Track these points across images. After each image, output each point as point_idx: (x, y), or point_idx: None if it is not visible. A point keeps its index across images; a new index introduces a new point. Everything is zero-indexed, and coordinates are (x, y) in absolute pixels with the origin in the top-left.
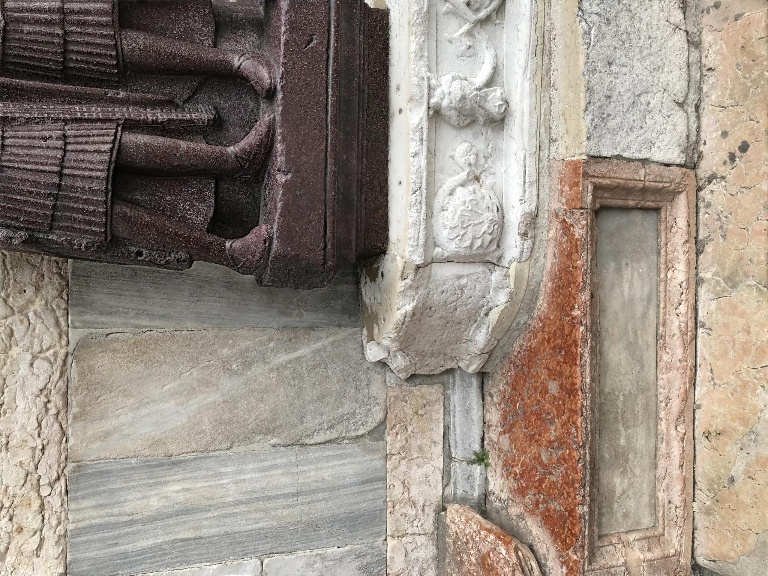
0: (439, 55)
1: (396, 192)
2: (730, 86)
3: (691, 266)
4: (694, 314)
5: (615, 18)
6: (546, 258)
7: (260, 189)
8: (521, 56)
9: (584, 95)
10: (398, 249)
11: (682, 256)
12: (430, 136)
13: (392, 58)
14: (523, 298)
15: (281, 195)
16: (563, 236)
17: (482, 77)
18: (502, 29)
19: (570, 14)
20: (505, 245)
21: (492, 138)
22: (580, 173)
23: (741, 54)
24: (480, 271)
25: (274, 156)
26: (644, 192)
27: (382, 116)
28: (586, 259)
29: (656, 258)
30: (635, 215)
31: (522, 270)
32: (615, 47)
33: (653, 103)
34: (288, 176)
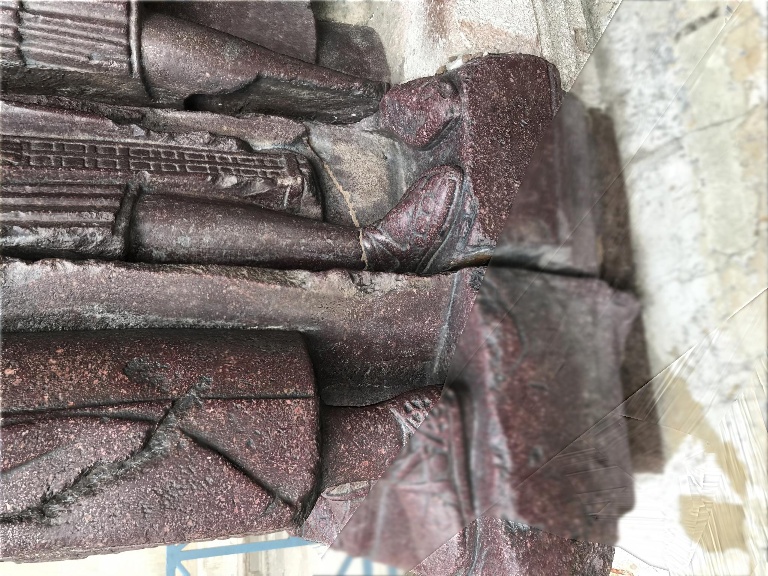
0: None
1: None
2: None
3: None
4: None
5: None
6: None
7: None
8: None
9: None
10: None
11: None
12: None
13: None
14: None
15: None
16: None
17: None
18: None
19: None
20: None
21: None
22: None
23: None
24: None
25: None
26: None
27: None
28: None
29: None
30: None
31: None
32: None
33: None
34: None
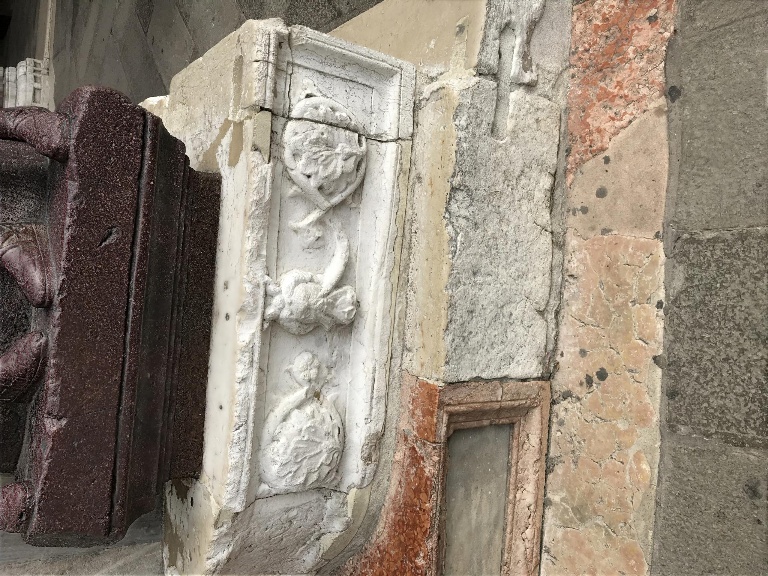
0: (281, 248)
1: (215, 415)
2: (592, 303)
3: (540, 486)
4: (540, 538)
5: (483, 222)
6: (390, 482)
7: (26, 406)
8: (377, 249)
9: (446, 313)
10: (213, 489)
11: (532, 476)
12: (263, 350)
13: (221, 241)
14: (361, 524)
15: (50, 450)
16: (411, 466)
17: (331, 276)
18: (358, 214)
19: (436, 213)
20: (345, 469)
21: (338, 343)
22: (435, 402)
23: (605, 273)
24: (313, 499)
25: (44, 390)
26: (499, 410)
27: (204, 311)
28: (436, 501)
29: (506, 476)
30: (488, 432)
31: (362, 497)
32: (481, 254)
33: (515, 314)
34: (62, 421)
